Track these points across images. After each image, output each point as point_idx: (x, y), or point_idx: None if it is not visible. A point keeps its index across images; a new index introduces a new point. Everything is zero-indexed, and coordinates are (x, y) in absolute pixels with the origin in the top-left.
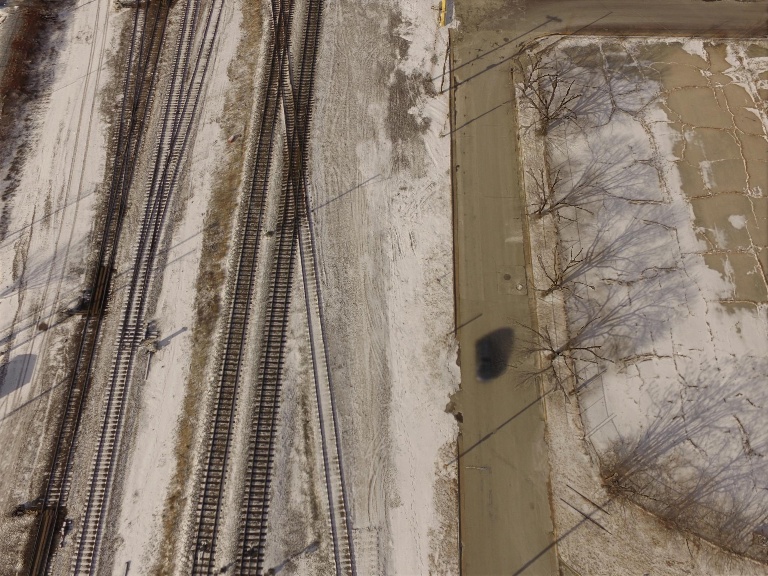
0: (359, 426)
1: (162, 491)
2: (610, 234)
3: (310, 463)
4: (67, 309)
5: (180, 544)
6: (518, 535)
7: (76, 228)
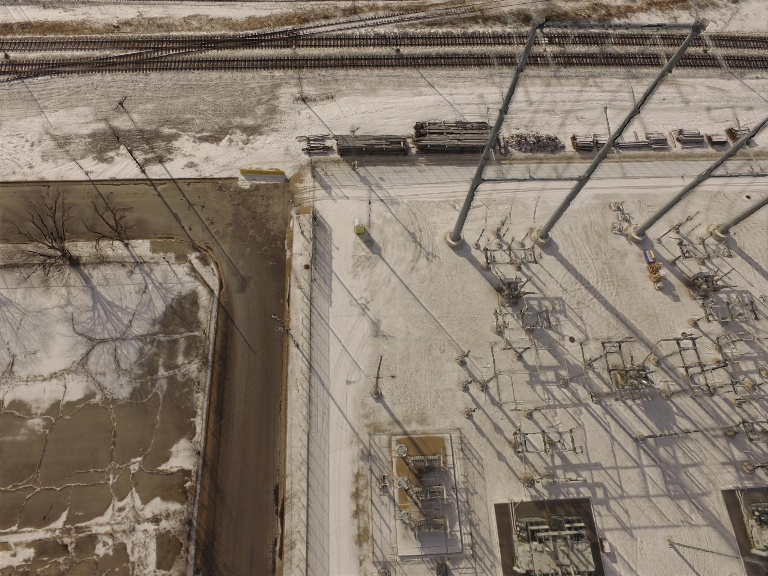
0: None
1: None
2: None
3: None
4: None
5: None
6: None
7: None
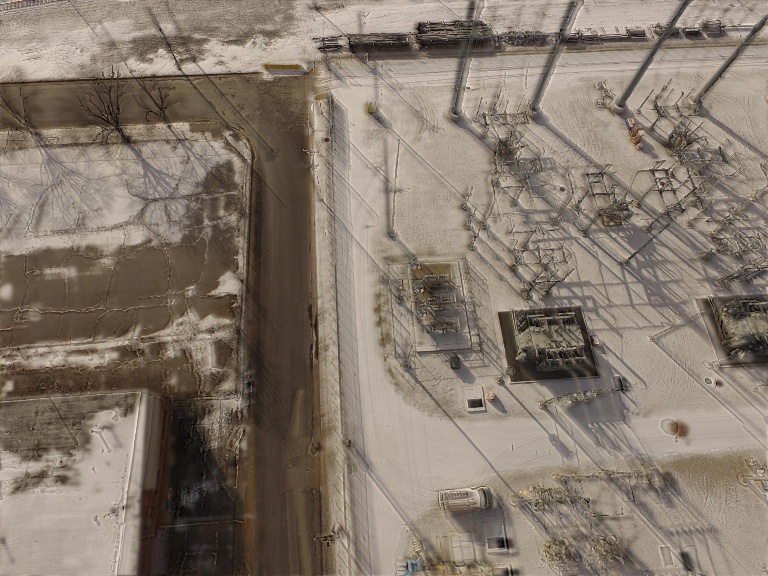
0: None
1: None
2: (4, 187)
3: None
4: None
5: None
6: None
7: None
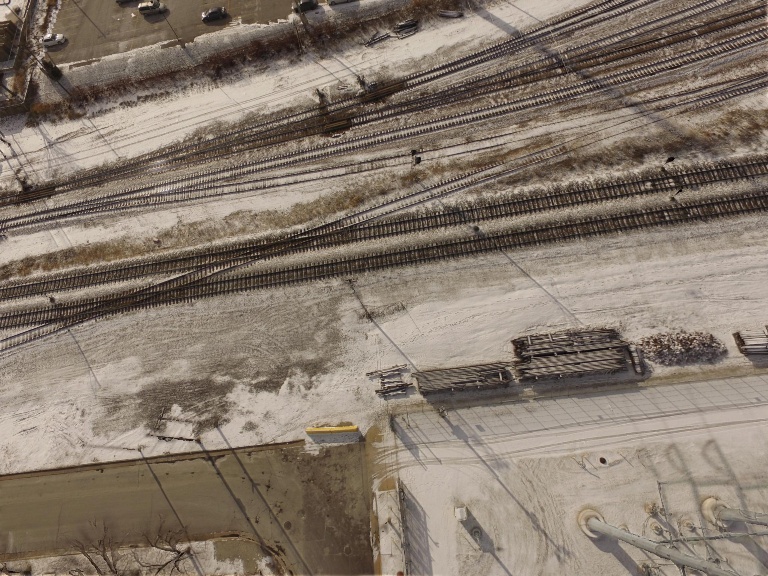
0: None
1: None
2: None
3: None
4: (24, 180)
5: None
6: None
7: (90, 159)
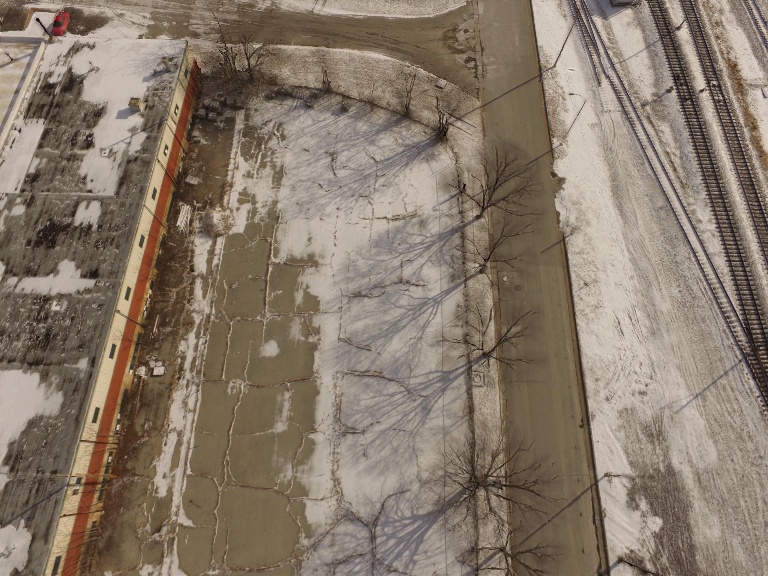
0: (633, 169)
1: (764, 133)
2: (410, 334)
3: (663, 146)
4: None
5: (737, 104)
6: (507, 110)
7: None
